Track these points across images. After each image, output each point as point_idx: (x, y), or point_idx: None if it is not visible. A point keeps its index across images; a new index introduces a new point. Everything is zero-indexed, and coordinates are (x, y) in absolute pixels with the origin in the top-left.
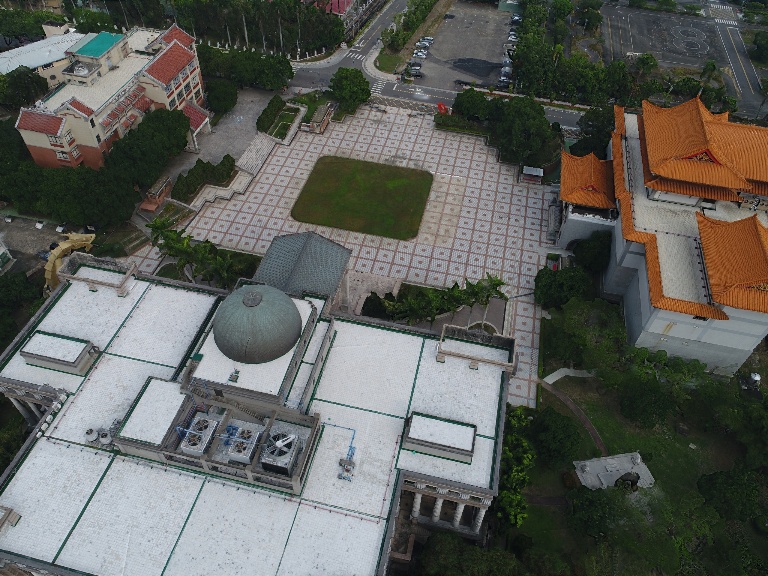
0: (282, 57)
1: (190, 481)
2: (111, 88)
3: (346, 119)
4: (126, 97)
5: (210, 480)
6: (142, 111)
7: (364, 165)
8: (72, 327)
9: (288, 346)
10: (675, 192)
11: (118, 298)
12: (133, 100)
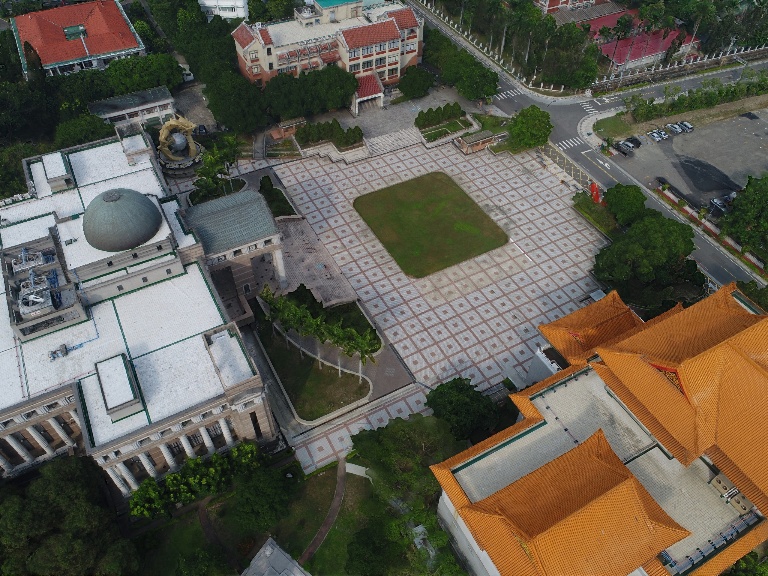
0: (491, 73)
1: (3, 286)
2: (314, 34)
3: (503, 154)
4: (316, 45)
5: None
6: (324, 62)
7: (462, 198)
8: (88, 164)
9: (113, 247)
10: (618, 396)
11: (127, 164)
12: (320, 50)
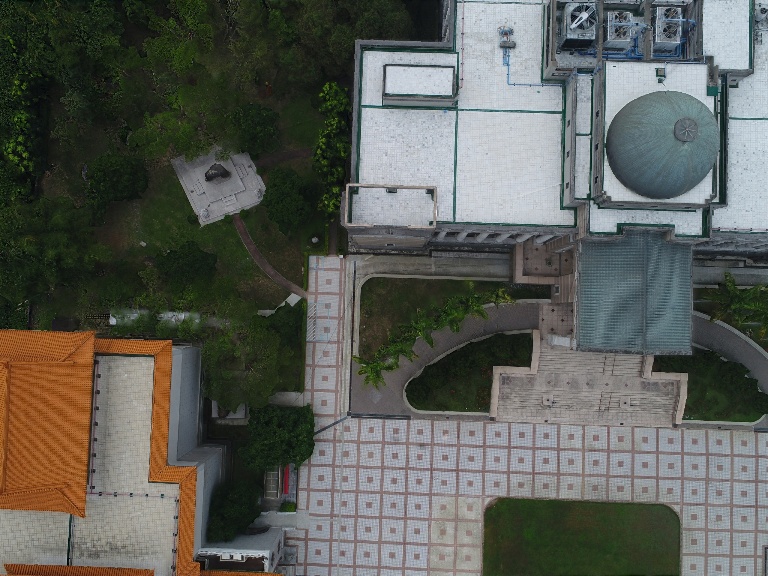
0: None
1: None
2: None
3: None
4: None
5: (636, 2)
6: None
7: None
8: None
9: None
10: (108, 568)
11: None
12: None
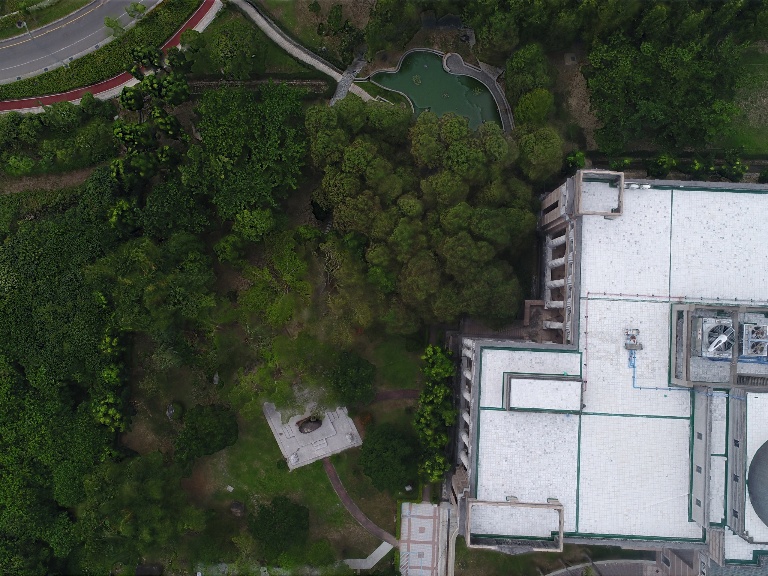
0: None
1: None
2: None
3: None
4: None
5: (767, 302)
6: None
7: None
8: None
9: (760, 461)
10: None
11: None
12: None
